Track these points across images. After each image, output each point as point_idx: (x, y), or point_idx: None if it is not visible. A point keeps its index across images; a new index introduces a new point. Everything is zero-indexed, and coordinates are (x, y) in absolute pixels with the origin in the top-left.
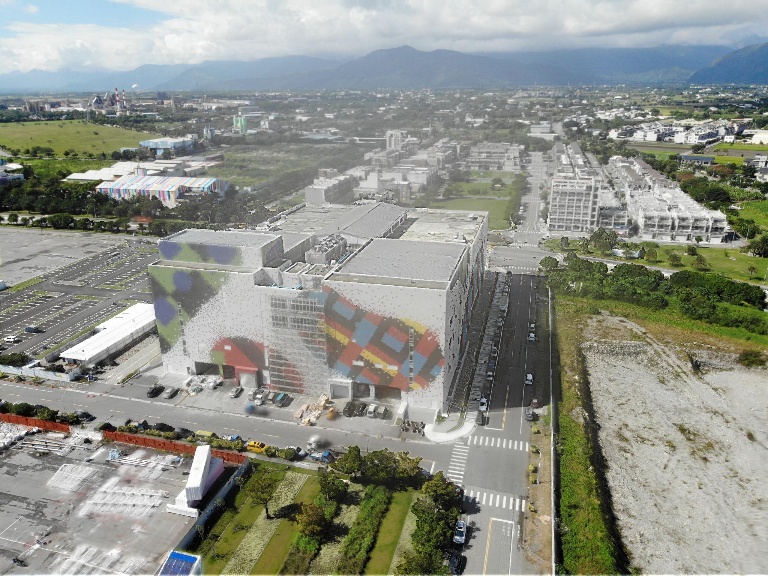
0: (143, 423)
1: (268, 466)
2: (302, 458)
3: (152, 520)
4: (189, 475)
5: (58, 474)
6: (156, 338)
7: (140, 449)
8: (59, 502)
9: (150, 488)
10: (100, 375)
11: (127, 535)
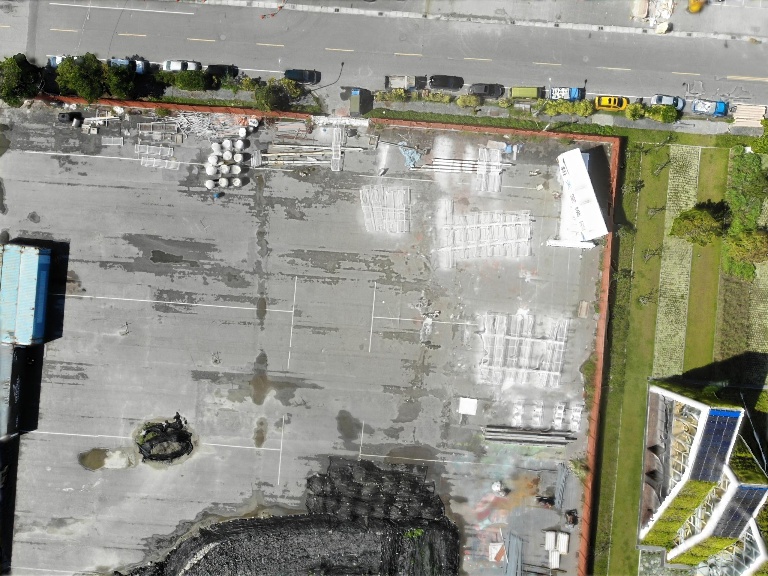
0: (415, 84)
1: (640, 140)
2: (679, 113)
3: (537, 260)
4: (580, 212)
5: (367, 211)
6: None
7: (439, 135)
8: (402, 253)
9: (502, 209)
10: None
11: (522, 287)
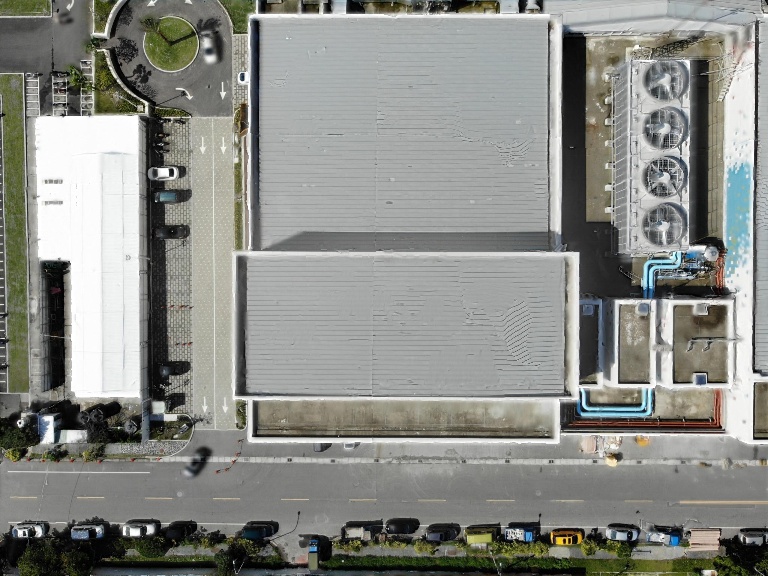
0: (371, 537)
1: (597, 571)
2: (635, 541)
3: None
4: None
5: None
6: (185, 250)
7: None
8: None
9: None
10: (185, 408)
11: None
